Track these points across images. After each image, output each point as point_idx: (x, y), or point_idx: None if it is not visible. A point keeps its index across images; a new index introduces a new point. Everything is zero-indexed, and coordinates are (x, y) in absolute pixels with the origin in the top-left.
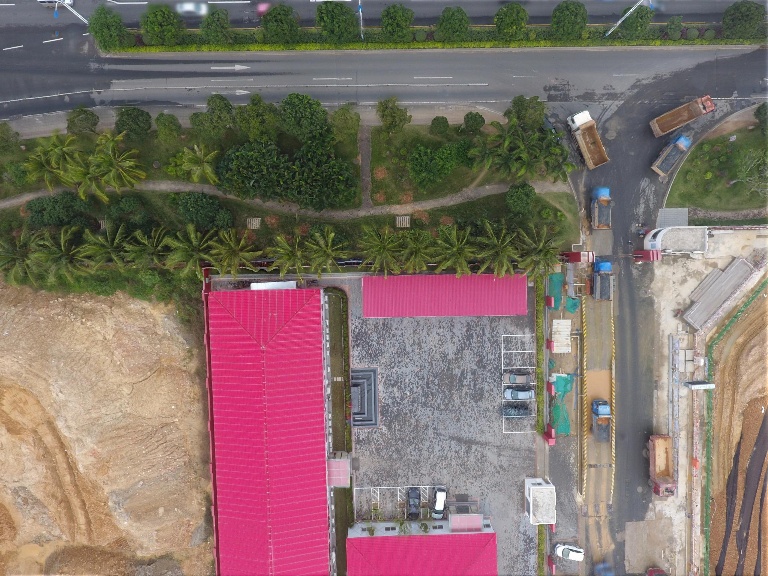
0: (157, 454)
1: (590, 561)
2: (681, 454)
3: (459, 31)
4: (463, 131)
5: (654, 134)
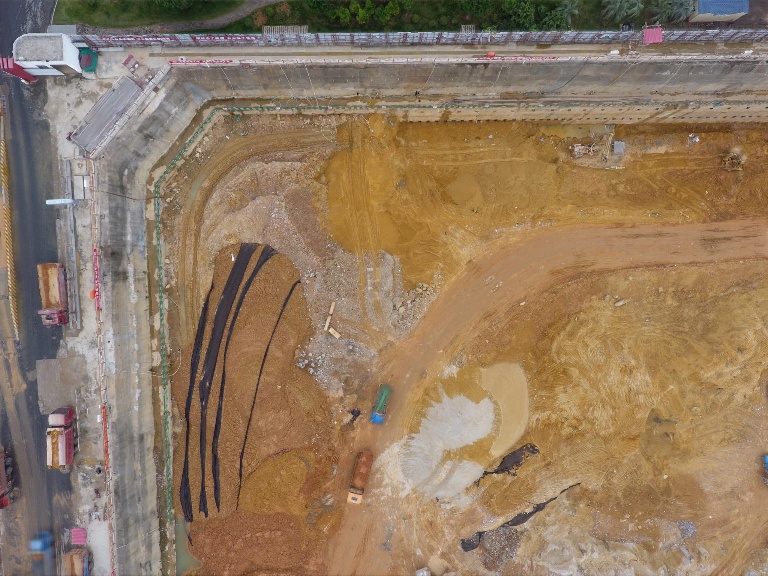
0: None
1: (1, 402)
2: (89, 287)
3: None
4: None
5: None
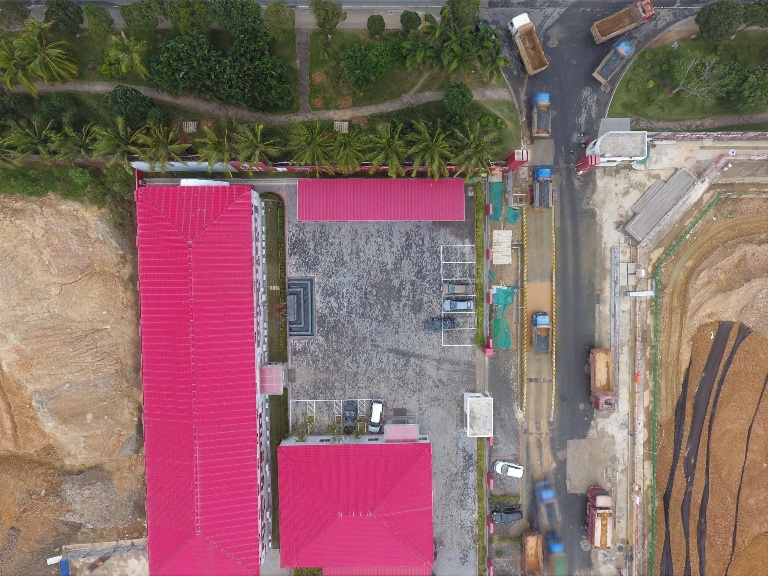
0: (86, 358)
1: (531, 480)
2: (623, 370)
3: None
4: (402, 35)
5: (595, 40)
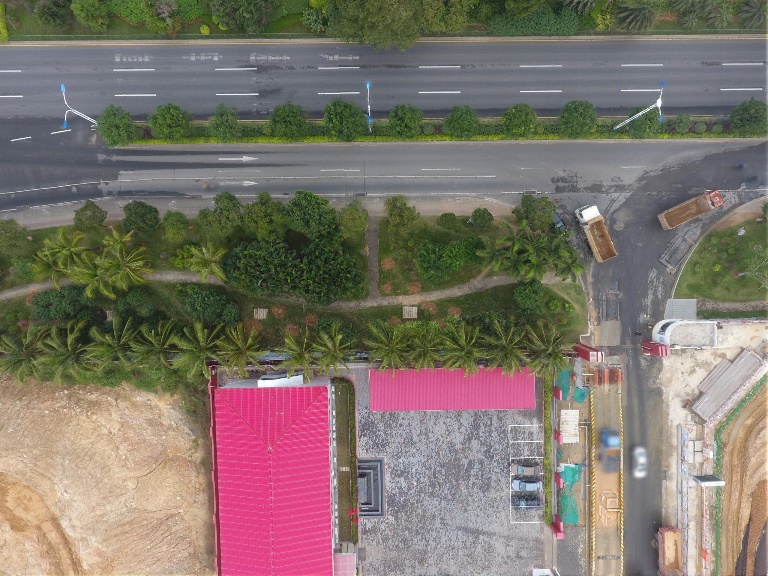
0: (162, 548)
1: None
2: (690, 545)
3: (467, 130)
4: (471, 223)
5: (662, 227)
